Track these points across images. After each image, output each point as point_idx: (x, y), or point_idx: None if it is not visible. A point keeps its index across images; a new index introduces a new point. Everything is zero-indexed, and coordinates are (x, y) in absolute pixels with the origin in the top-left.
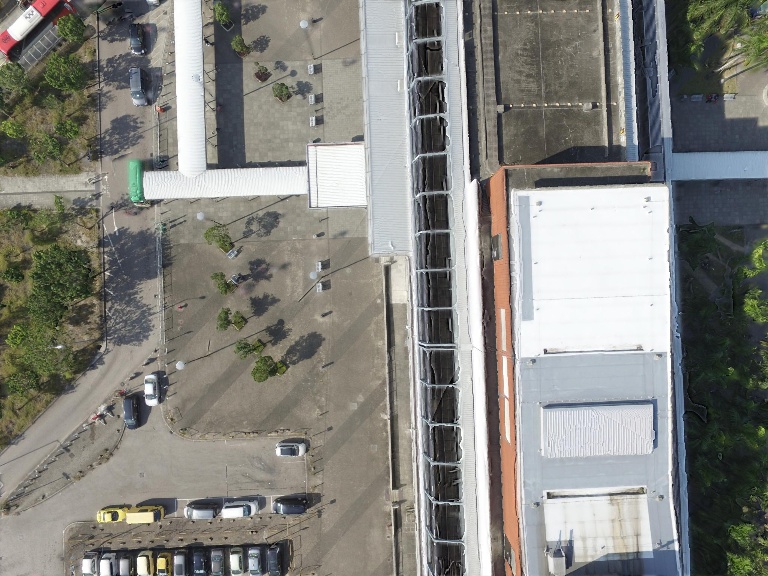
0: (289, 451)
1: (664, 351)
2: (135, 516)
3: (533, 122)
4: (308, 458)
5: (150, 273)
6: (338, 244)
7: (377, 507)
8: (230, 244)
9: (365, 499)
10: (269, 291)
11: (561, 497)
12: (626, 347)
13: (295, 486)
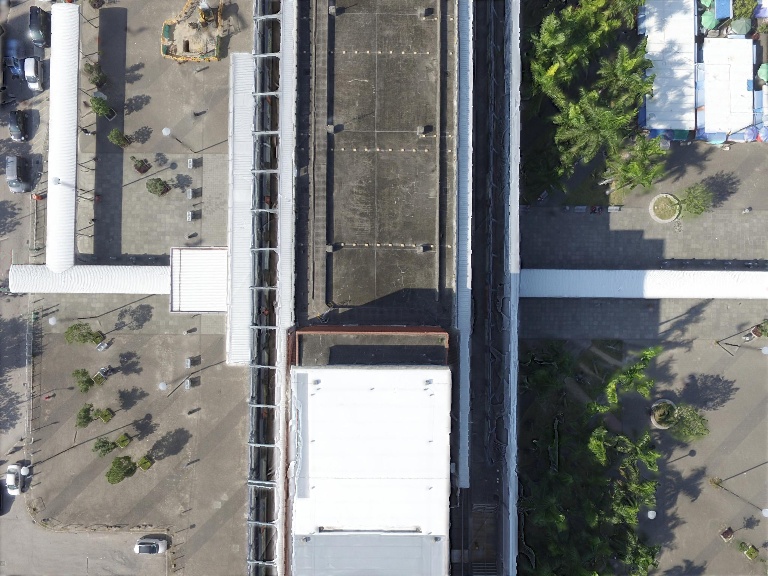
0: (148, 549)
1: (443, 534)
2: None
3: (365, 262)
4: (169, 555)
5: (20, 361)
6: (210, 341)
7: None
8: (101, 336)
9: None
10: (138, 385)
11: None
12: (405, 528)
13: None
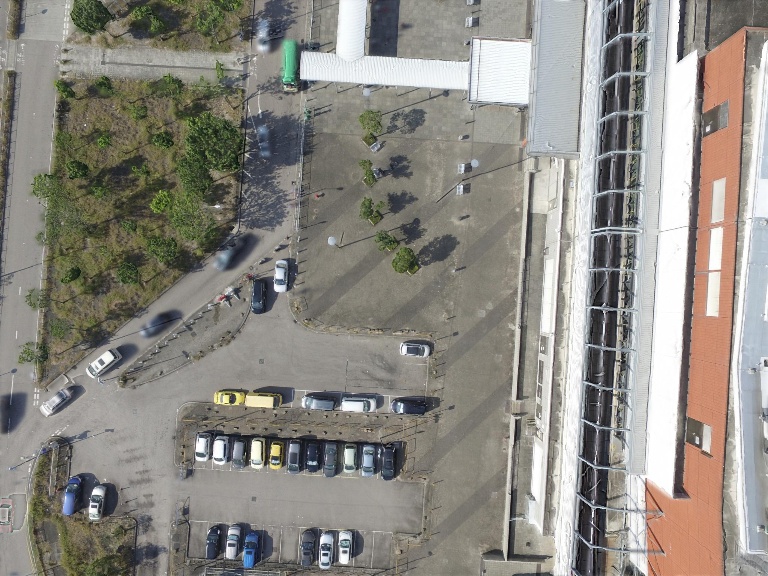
0: (415, 350)
1: None
2: (255, 399)
3: (742, 10)
4: (431, 361)
5: (290, 159)
6: (482, 148)
7: (496, 418)
8: (373, 138)
9: (484, 408)
10: (408, 189)
11: None
12: None
13: (415, 388)
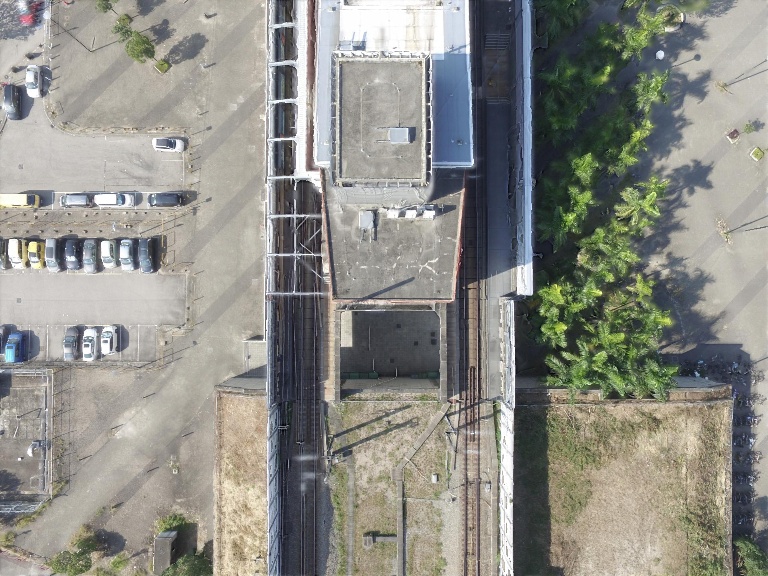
0: (165, 142)
1: None
2: (8, 197)
3: None
4: (186, 156)
5: None
6: None
7: (252, 207)
8: None
9: (241, 198)
10: None
11: (358, 5)
12: None
13: (172, 184)
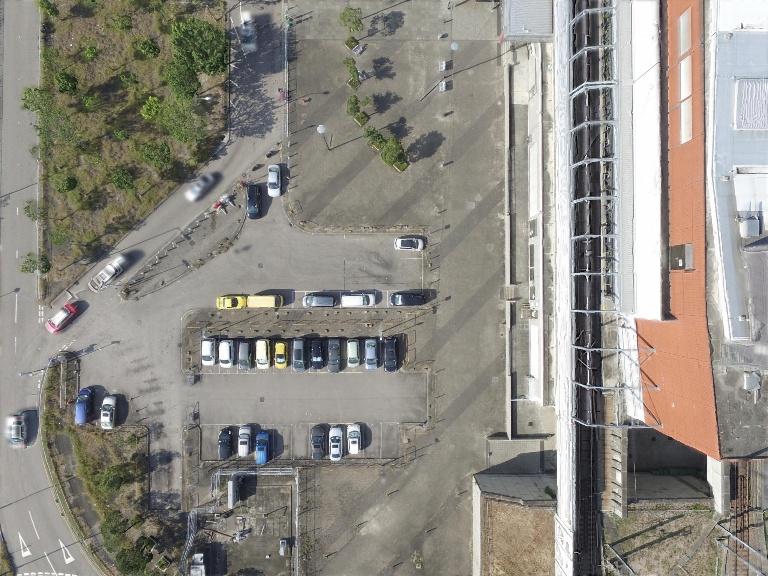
0: (409, 243)
1: None
2: (257, 299)
3: None
4: (425, 255)
5: (275, 67)
6: (461, 46)
7: (491, 305)
8: (355, 41)
9: (480, 297)
10: (392, 89)
11: (750, 173)
12: None
13: (411, 282)
